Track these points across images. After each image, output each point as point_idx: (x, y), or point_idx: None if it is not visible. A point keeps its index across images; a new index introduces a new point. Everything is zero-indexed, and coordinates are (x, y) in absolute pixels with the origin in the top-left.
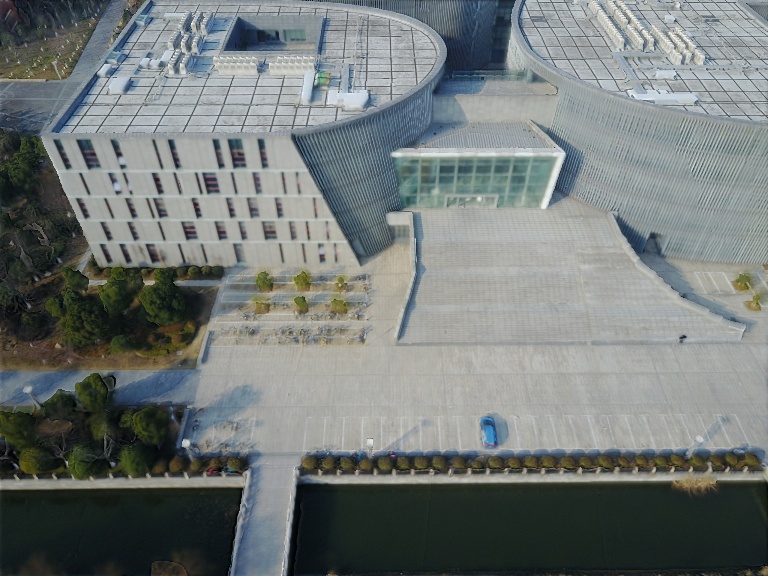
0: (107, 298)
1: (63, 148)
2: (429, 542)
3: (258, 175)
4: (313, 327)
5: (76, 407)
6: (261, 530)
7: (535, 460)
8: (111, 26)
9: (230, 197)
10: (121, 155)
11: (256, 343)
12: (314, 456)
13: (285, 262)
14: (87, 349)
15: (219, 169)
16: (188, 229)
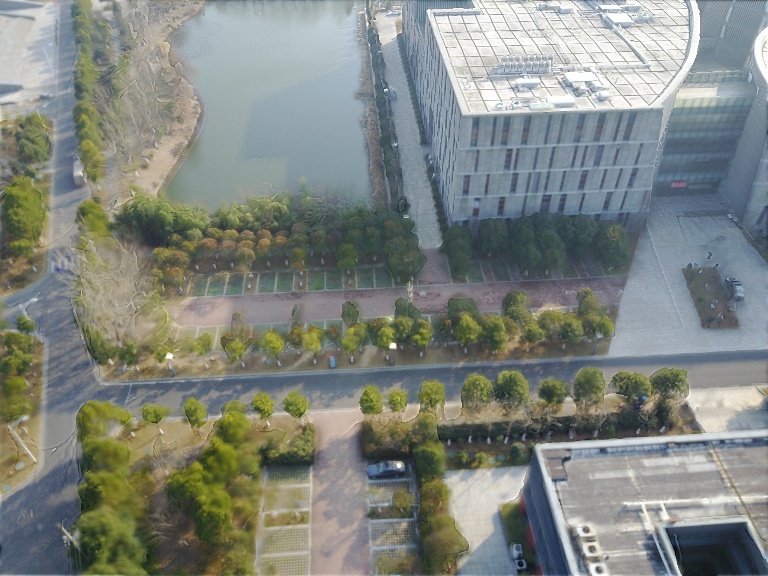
0: None
1: None
2: None
3: None
4: None
5: None
6: None
7: None
8: None
9: None
10: None
11: None
12: None
13: None
14: None
15: None
16: None
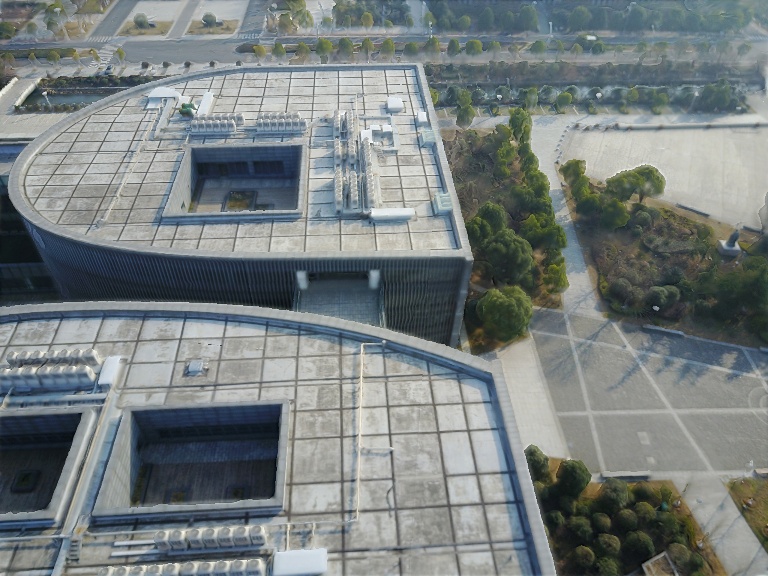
0: None
1: None
2: None
3: None
4: None
5: None
6: None
7: None
8: None
9: None
10: None
11: None
12: None
13: None
14: None
15: None
16: None
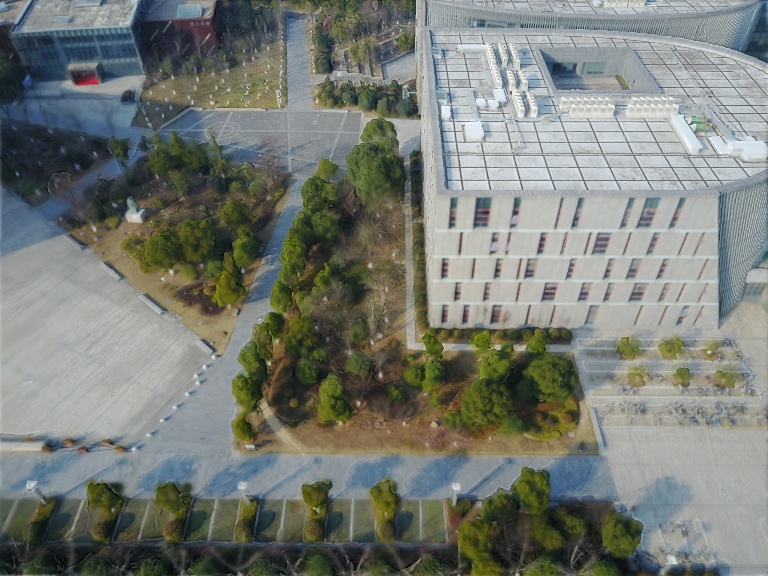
0: (493, 373)
1: (456, 206)
2: None
3: (658, 235)
4: (705, 404)
5: (520, 509)
6: None
7: None
8: (303, 49)
9: (614, 258)
10: (516, 214)
11: (652, 423)
12: None
13: (637, 324)
14: (471, 430)
15: (619, 229)
16: (547, 290)
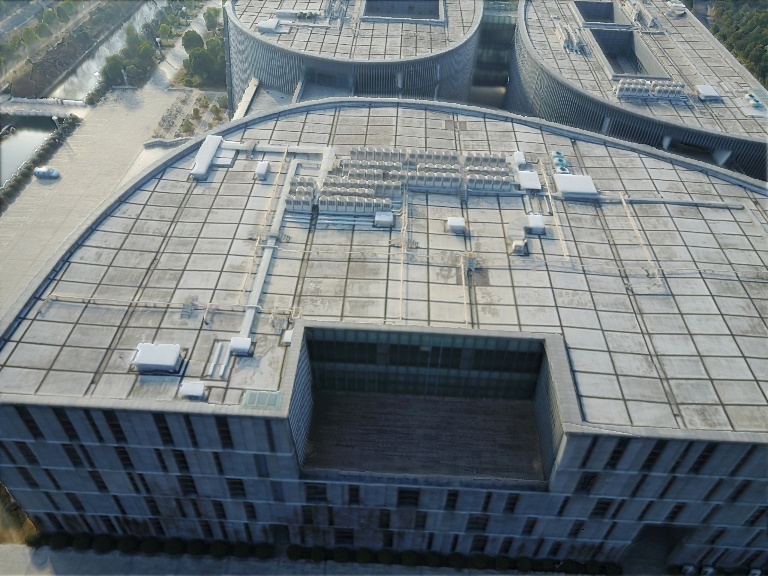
0: None
1: None
2: (11, 165)
3: None
4: (177, 121)
5: None
6: (48, 107)
7: (10, 185)
8: None
9: None
10: None
11: None
12: (76, 118)
13: None
14: None
15: None
16: None
